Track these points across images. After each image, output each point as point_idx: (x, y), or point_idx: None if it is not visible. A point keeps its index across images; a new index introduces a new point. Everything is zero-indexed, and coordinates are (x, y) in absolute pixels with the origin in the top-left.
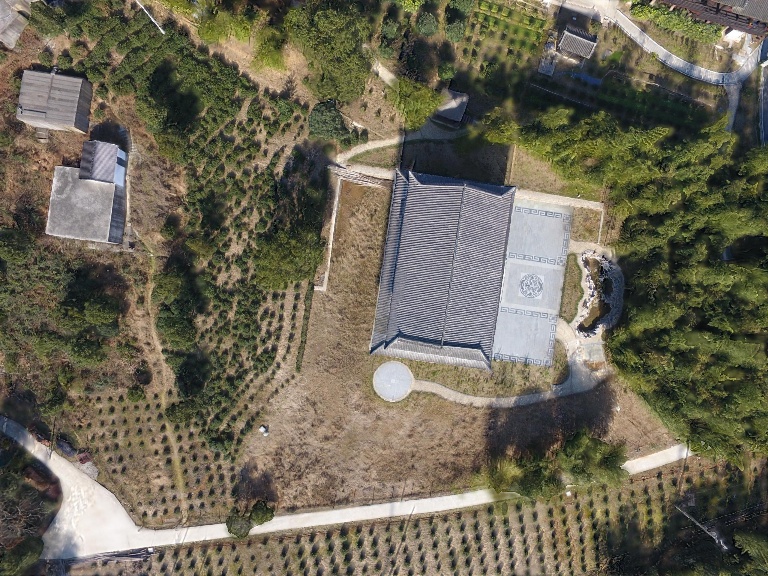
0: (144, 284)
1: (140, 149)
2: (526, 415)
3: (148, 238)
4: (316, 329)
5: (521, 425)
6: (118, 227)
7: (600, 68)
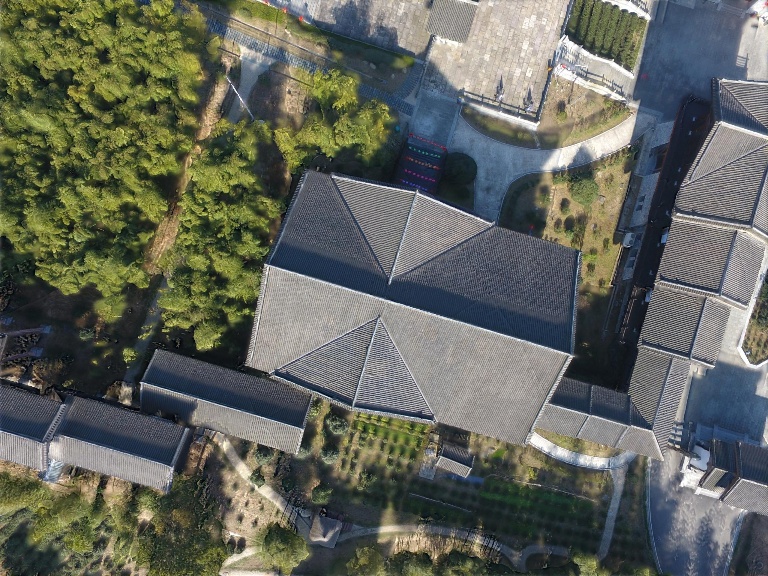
0: None
1: None
2: None
3: None
4: None
5: None
6: None
7: (482, 467)
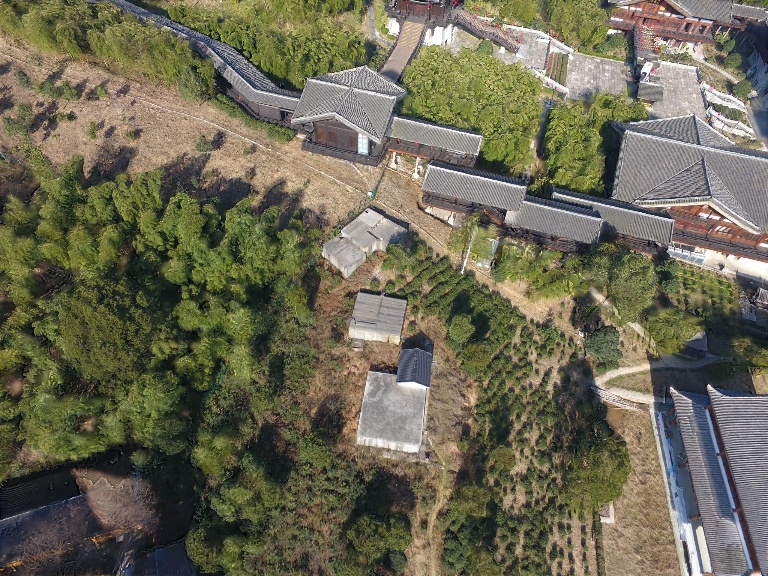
0: (434, 503)
1: (439, 361)
2: None
3: (443, 448)
4: (613, 575)
5: None
6: None
7: None
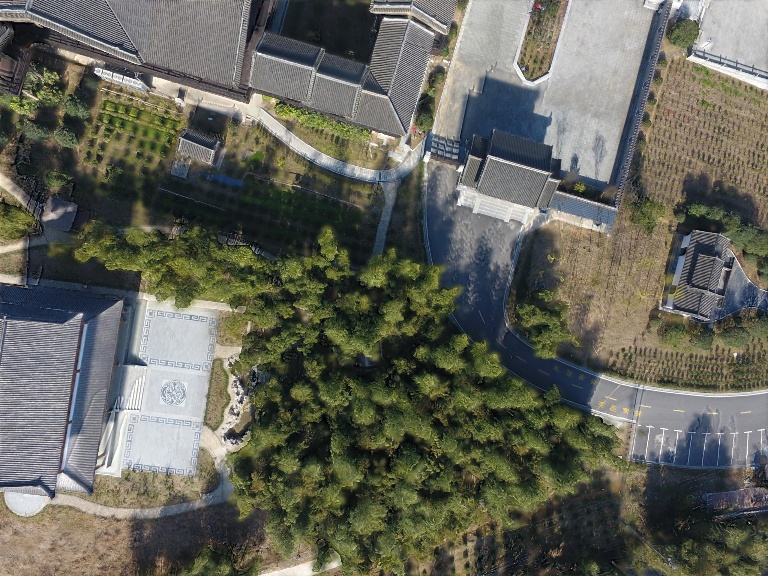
0: None
1: None
2: (172, 526)
3: None
4: None
5: (168, 536)
6: None
7: (241, 169)
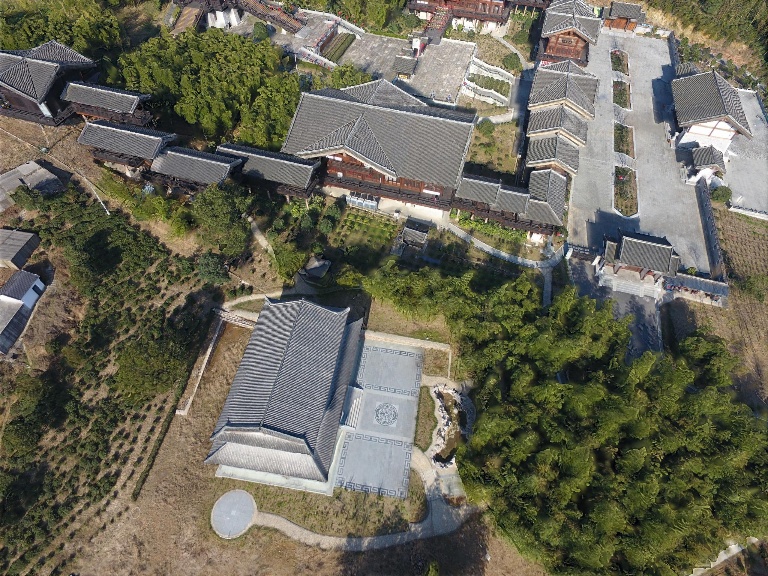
0: (10, 393)
1: (58, 284)
2: (380, 561)
3: (32, 351)
4: (166, 453)
5: (374, 575)
6: (9, 339)
7: (438, 253)
